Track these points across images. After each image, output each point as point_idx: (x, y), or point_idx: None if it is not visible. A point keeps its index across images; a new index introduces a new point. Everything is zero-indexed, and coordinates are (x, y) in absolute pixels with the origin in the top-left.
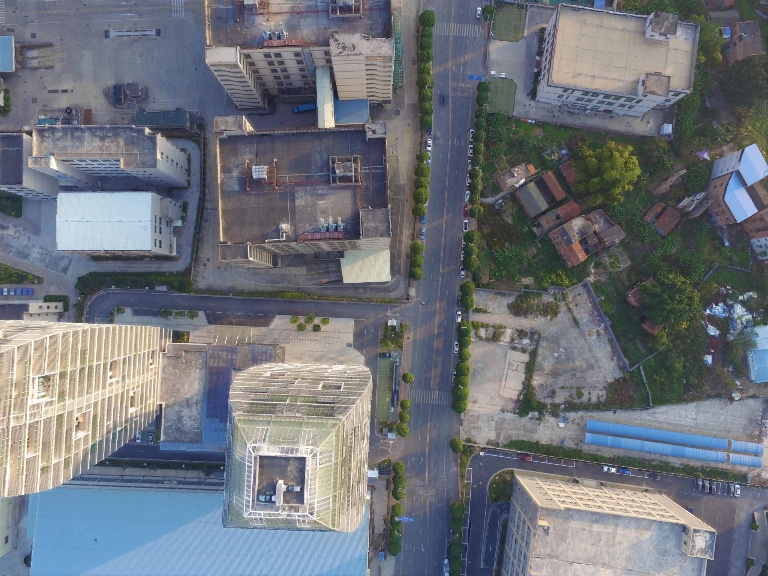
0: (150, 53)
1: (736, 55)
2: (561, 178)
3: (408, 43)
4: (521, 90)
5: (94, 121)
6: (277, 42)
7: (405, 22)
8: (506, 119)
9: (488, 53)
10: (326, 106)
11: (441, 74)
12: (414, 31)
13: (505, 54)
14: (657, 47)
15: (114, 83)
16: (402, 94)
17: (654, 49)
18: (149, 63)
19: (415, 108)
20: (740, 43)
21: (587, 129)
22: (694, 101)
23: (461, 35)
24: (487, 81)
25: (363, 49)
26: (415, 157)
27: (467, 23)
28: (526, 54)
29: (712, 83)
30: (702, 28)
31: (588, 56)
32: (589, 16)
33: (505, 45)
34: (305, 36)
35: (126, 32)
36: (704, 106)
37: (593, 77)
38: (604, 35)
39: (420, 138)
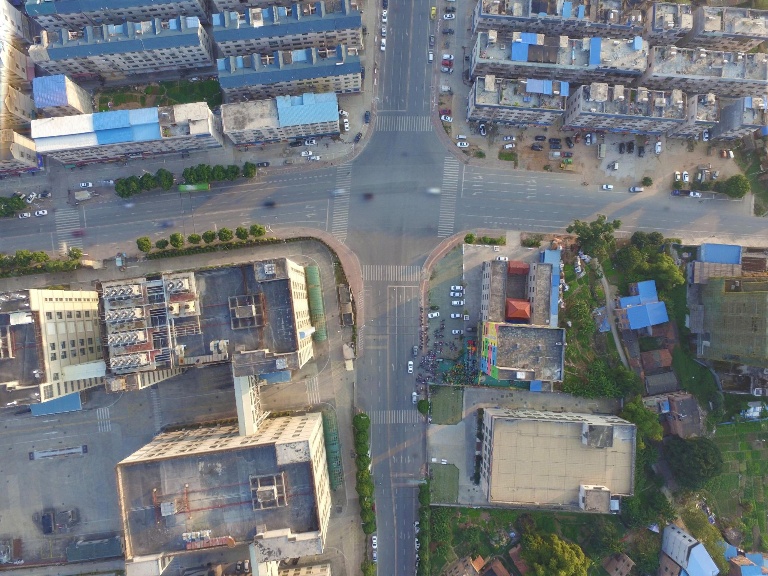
0: (78, 472)
1: (676, 429)
2: (511, 563)
3: (345, 435)
4: (464, 474)
5: (25, 550)
6: (200, 543)
7: (340, 414)
8: (450, 514)
9: (427, 439)
10: (260, 567)
11: (381, 465)
12: (350, 422)
13: (445, 438)
14: (595, 451)
15: (43, 507)
16: (343, 490)
17: (592, 454)
18: (78, 483)
19: (357, 503)
20: (679, 422)
21: (534, 509)
22: (638, 482)
23: (398, 422)
24: (428, 471)
25: (289, 553)
26: (361, 555)
27: (404, 409)
28: (466, 437)
29: (655, 456)
30: (639, 421)
31: (526, 468)
32: (524, 425)
33: (444, 429)
34: (230, 529)
35: (51, 452)
36: (650, 470)
37: (533, 489)
38: (541, 444)
39: (365, 534)
